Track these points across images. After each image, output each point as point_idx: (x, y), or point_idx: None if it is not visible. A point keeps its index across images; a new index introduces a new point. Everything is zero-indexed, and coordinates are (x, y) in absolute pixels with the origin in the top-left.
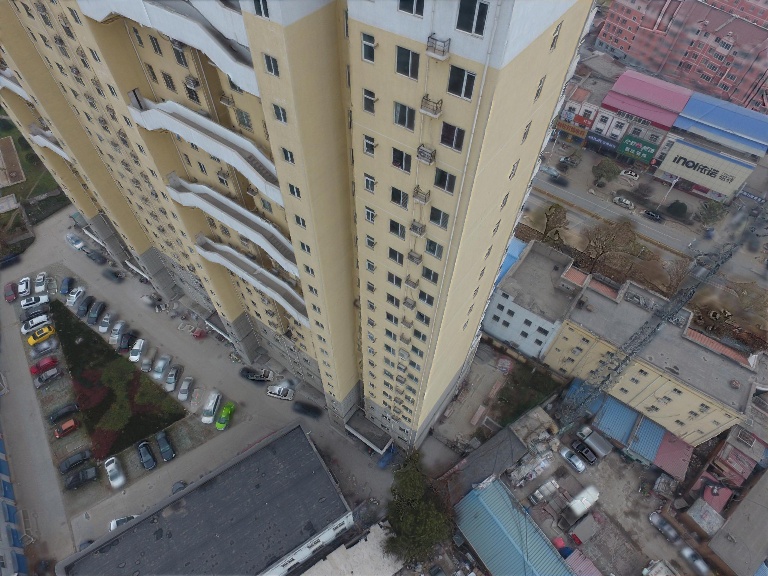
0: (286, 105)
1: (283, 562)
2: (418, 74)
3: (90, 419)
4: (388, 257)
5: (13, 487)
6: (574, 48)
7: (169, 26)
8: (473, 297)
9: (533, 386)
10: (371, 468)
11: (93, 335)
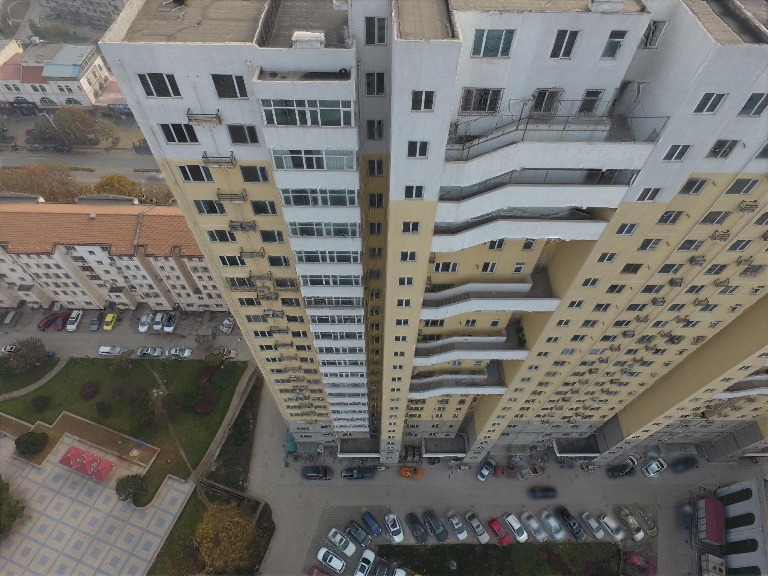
0: None
1: None
2: None
3: None
4: None
5: None
6: None
7: None
8: None
9: None
10: (765, 472)
11: (462, 549)
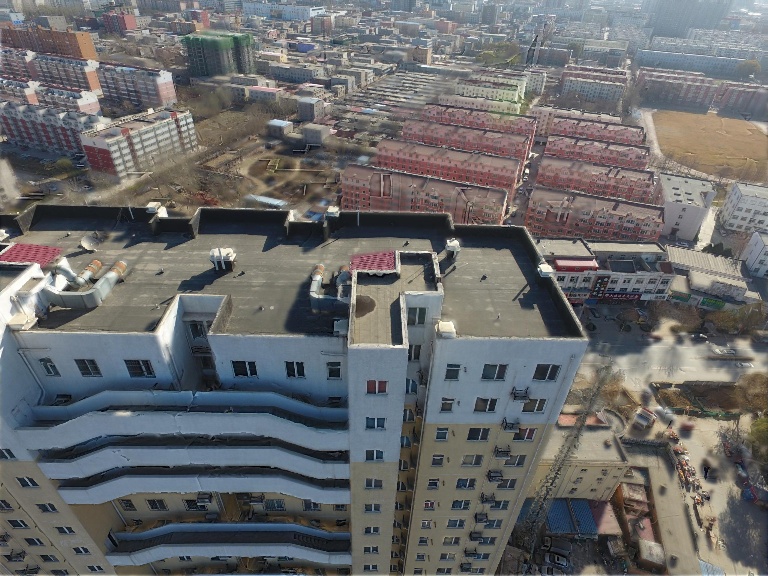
0: (384, 502)
1: None
2: (488, 438)
3: None
4: (443, 544)
5: None
6: None
7: (233, 486)
8: None
9: None
10: None
11: None
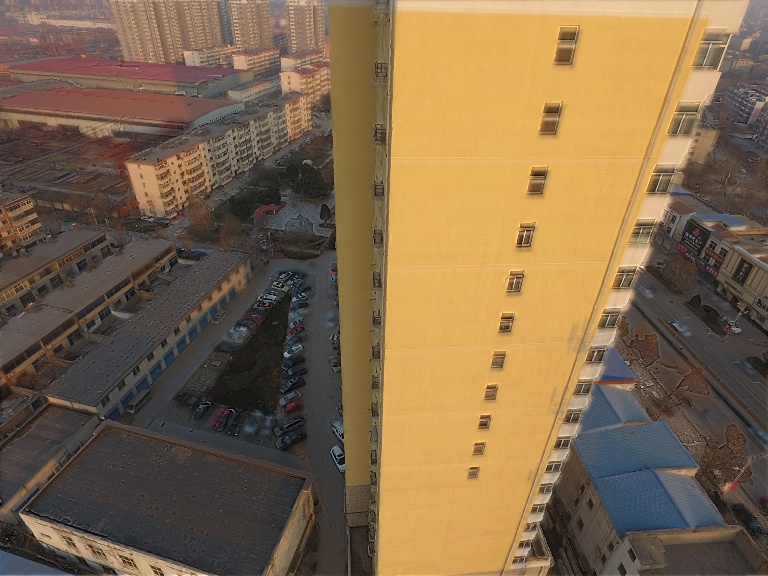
0: None
1: (179, 570)
2: None
3: (228, 370)
4: None
5: (161, 374)
6: (659, 108)
7: None
8: (480, 426)
9: None
10: None
11: (284, 325)
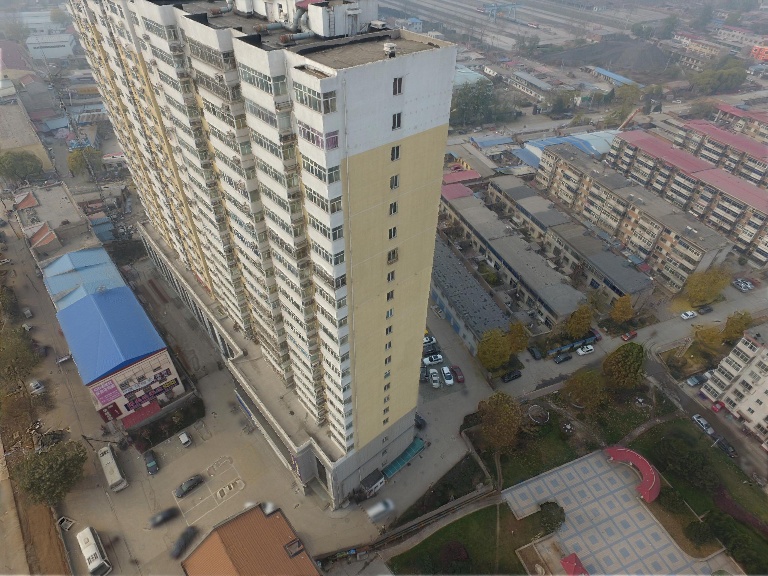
0: None
1: None
2: None
3: None
4: None
5: None
6: None
7: None
8: None
9: (123, 256)
10: None
11: None
